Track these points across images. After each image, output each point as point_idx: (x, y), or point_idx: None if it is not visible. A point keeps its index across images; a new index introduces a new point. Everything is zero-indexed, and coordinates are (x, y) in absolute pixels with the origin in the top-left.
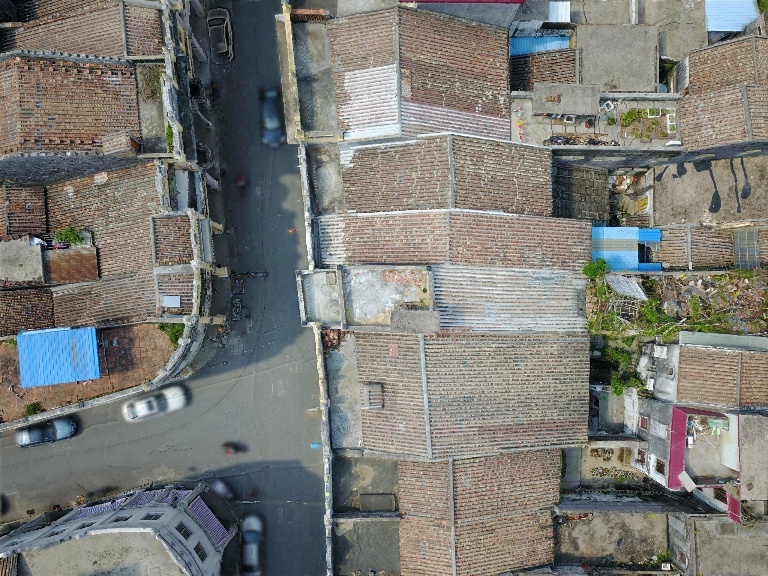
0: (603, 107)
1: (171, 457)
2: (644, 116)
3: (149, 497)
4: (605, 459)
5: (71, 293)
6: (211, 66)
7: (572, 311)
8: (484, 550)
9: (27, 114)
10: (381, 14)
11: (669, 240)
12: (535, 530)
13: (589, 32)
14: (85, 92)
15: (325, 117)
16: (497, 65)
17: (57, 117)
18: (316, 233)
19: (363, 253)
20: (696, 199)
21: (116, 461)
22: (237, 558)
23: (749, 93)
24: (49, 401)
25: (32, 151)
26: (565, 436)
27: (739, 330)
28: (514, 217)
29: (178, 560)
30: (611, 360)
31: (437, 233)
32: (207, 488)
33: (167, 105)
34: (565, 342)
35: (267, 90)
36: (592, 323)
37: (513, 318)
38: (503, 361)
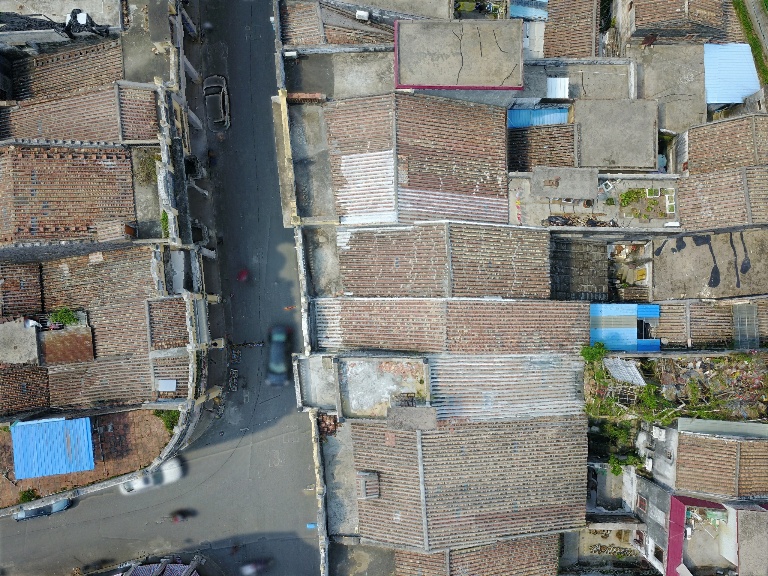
0: (602, 187)
1: (167, 529)
2: (643, 196)
3: (145, 572)
4: (603, 536)
5: (66, 371)
6: (208, 133)
7: (570, 394)
8: None
9: (21, 203)
10: (378, 99)
11: (668, 316)
12: None
13: (588, 107)
14: (80, 178)
15: (321, 200)
16: (495, 145)
17: (51, 204)
18: (312, 315)
19: (360, 338)
20: (695, 273)
21: (112, 533)
22: None
23: (749, 176)
24: (44, 488)
25: (26, 240)
26: (563, 521)
27: (738, 415)
28: (512, 302)
29: None
30: (609, 436)
31: (434, 322)
32: (203, 560)
33: (162, 193)
34: (563, 426)
35: (264, 157)
36: (590, 405)
37: (510, 405)
38: (500, 448)
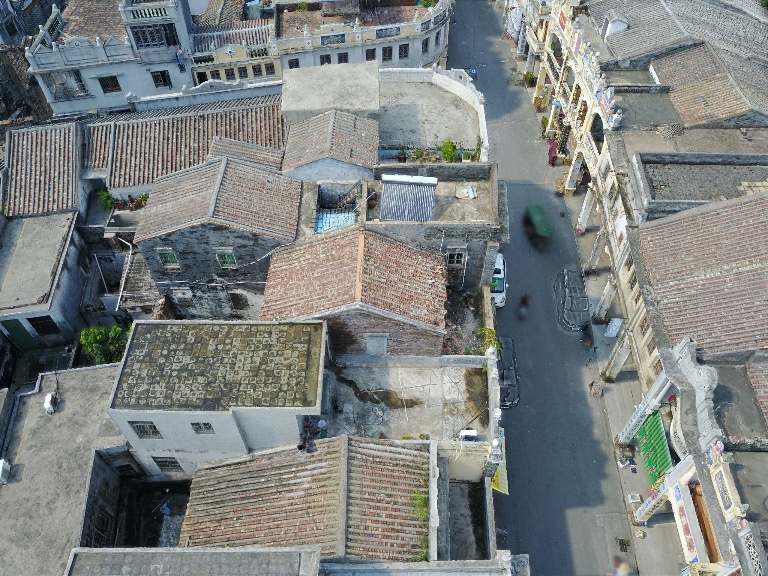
0: None
1: None
2: None
3: None
4: None
5: None
6: None
7: (765, 17)
8: None
9: None
10: None
11: None
12: None
13: None
14: None
15: None
16: None
17: None
18: None
19: None
20: None
21: None
22: None
23: None
24: None
25: None
26: None
27: None
28: None
29: None
30: None
31: None
32: None
33: None
34: None
35: (465, 5)
36: None
37: None
38: None
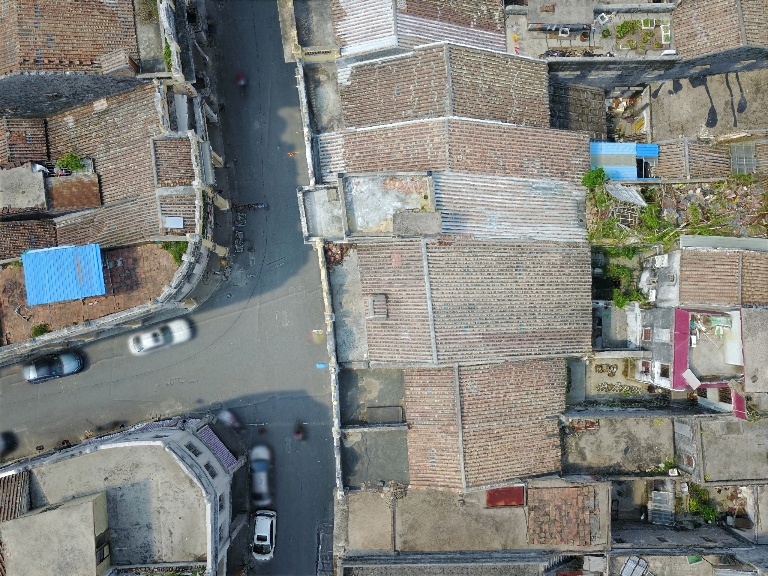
0: (597, 20)
1: (178, 390)
2: (638, 27)
3: (157, 427)
4: (610, 374)
5: (74, 223)
6: (206, 3)
7: (572, 222)
8: (492, 456)
9: (25, 35)
10: None
11: (667, 155)
12: (542, 438)
13: None
14: (82, 14)
15: (321, 34)
16: None
17: (55, 38)
18: (316, 152)
19: (363, 168)
20: (692, 114)
21: (123, 395)
22: (246, 488)
23: None
24: (56, 323)
25: (32, 71)
26: (569, 345)
27: (739, 234)
28: (512, 127)
29: (188, 470)
30: (613, 276)
31: (436, 142)
32: (215, 419)
33: (164, 22)
34: (566, 252)
35: (263, 25)
36: (593, 234)
37: (514, 227)
38: (505, 270)
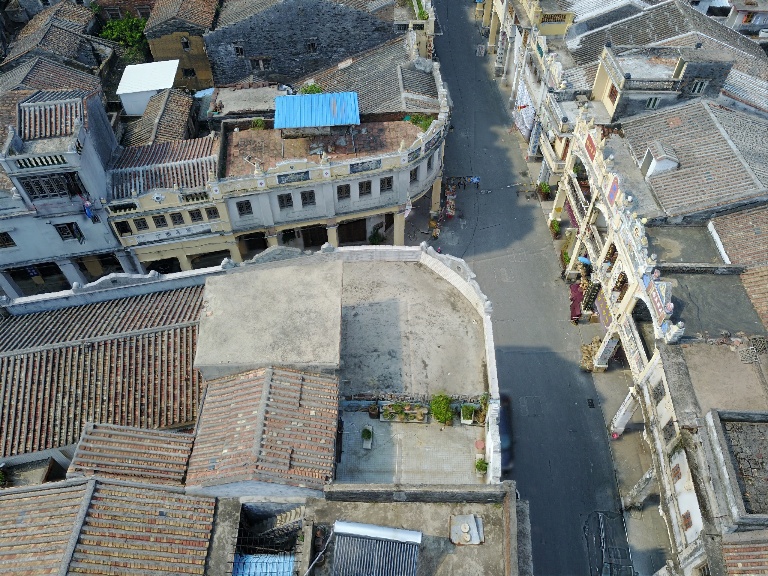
0: None
1: None
2: None
3: None
4: None
5: None
6: None
7: None
8: None
9: None
10: None
11: None
12: None
13: None
14: None
15: None
16: None
17: None
18: None
19: None
20: None
21: None
22: None
23: None
24: None
25: None
26: None
27: None
28: (753, 58)
29: None
30: None
31: None
32: None
33: None
34: None
35: (465, 82)
36: None
37: None
38: None
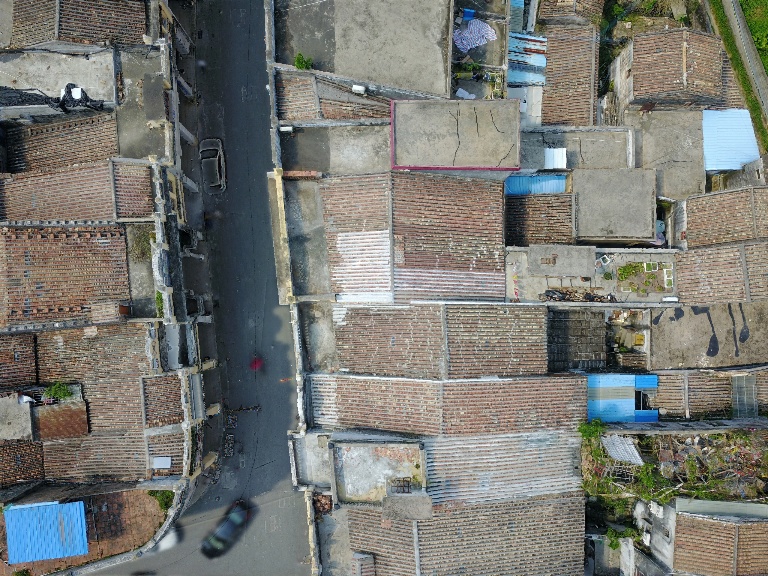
0: (599, 260)
1: None
2: (641, 270)
3: None
4: None
5: (61, 443)
6: (204, 195)
7: (567, 471)
8: None
9: (15, 284)
10: (374, 178)
11: (666, 386)
12: None
13: (585, 176)
14: (74, 257)
15: (317, 277)
16: (492, 219)
17: (45, 285)
18: (308, 391)
19: (355, 416)
20: (694, 342)
21: None
22: None
23: (747, 252)
24: (37, 568)
25: (20, 322)
26: None
27: (736, 493)
28: (508, 382)
29: None
30: (607, 507)
31: (430, 404)
32: None
33: (156, 275)
34: (560, 503)
35: (260, 220)
36: (588, 482)
37: (507, 485)
38: (497, 528)
